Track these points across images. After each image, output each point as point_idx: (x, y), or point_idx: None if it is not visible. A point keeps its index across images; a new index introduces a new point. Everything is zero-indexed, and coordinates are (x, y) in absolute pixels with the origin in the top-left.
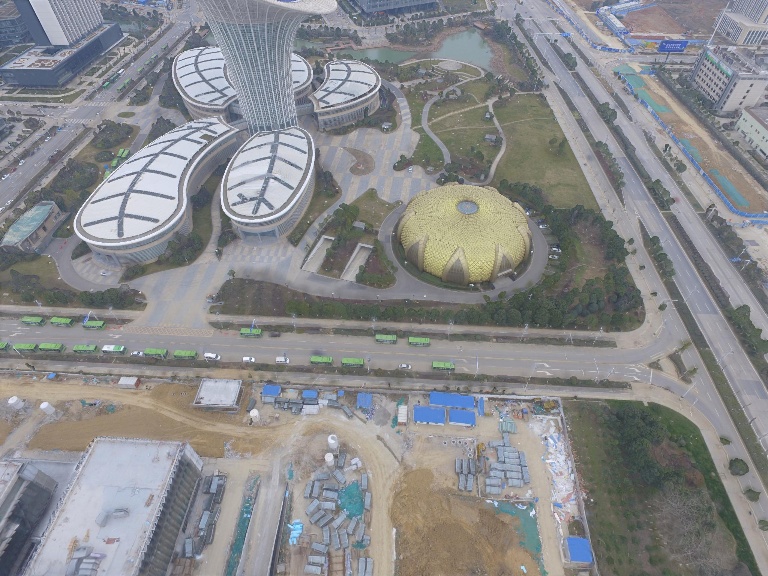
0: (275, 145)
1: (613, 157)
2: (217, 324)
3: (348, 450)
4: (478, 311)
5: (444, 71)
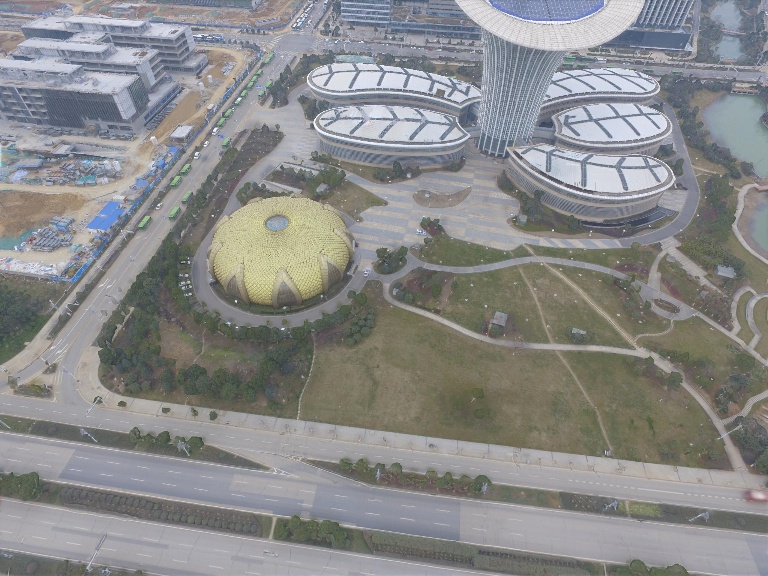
0: (420, 121)
1: (459, 513)
2: (242, 131)
3: (117, 179)
4: (170, 235)
5: (767, 312)
